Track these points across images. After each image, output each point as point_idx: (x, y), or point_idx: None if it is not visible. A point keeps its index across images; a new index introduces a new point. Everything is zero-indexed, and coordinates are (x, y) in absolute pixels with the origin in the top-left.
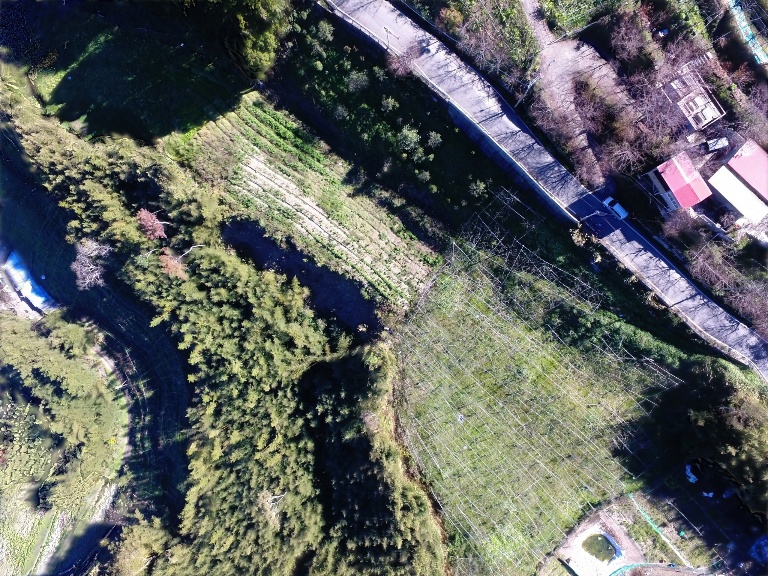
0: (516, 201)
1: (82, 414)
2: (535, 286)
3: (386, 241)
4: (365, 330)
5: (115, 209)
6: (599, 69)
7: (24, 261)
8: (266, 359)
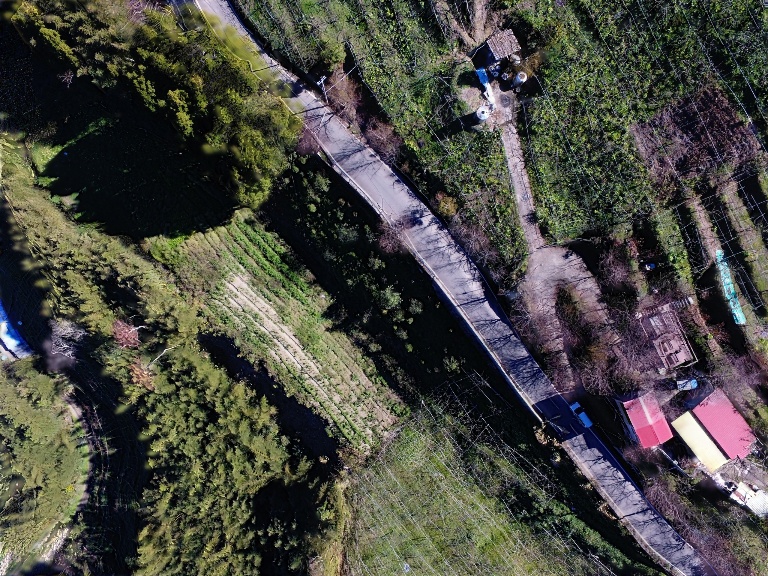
0: (486, 386)
1: (43, 460)
2: (495, 462)
3: (357, 383)
4: (326, 462)
5: (93, 302)
6: (584, 281)
7: (4, 299)
8: (226, 467)
